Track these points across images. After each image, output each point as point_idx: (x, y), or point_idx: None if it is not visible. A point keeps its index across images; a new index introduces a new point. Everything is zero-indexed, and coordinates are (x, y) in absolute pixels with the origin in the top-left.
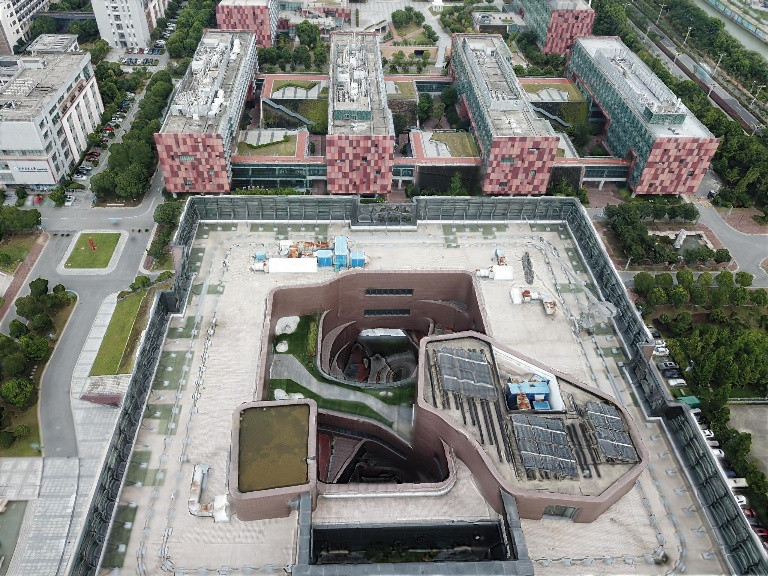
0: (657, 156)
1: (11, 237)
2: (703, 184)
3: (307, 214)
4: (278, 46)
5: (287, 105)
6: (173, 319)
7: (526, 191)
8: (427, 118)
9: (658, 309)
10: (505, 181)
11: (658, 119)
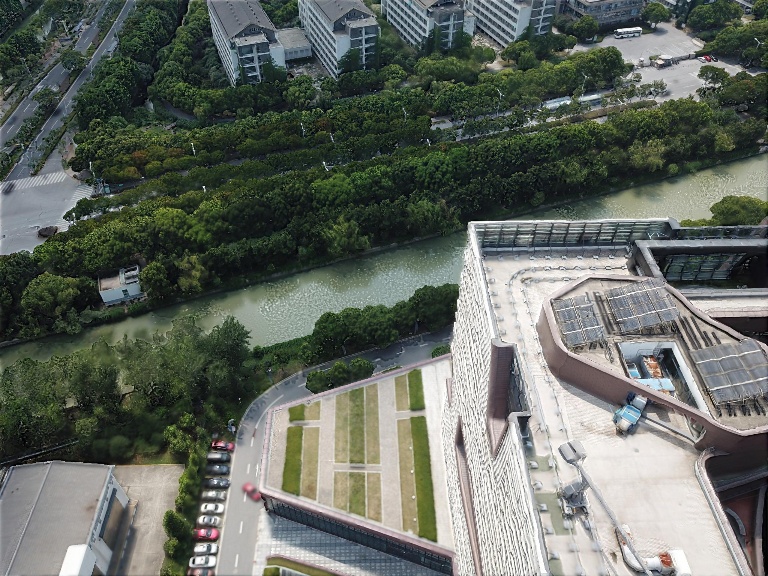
0: None
1: None
2: None
3: None
4: None
5: None
6: None
7: None
8: None
9: None
10: None
11: None
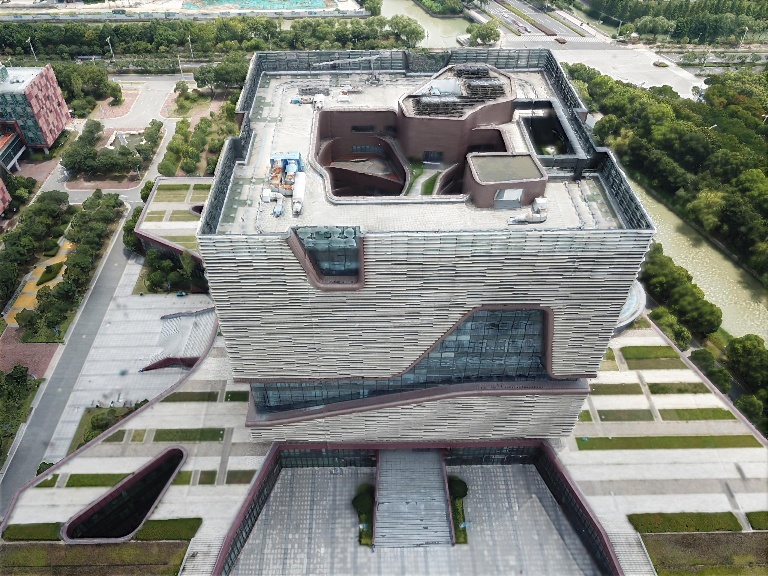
0: (36, 105)
1: None
2: None
3: None
4: None
5: None
6: None
7: (1, 209)
8: None
9: None
10: None
11: None
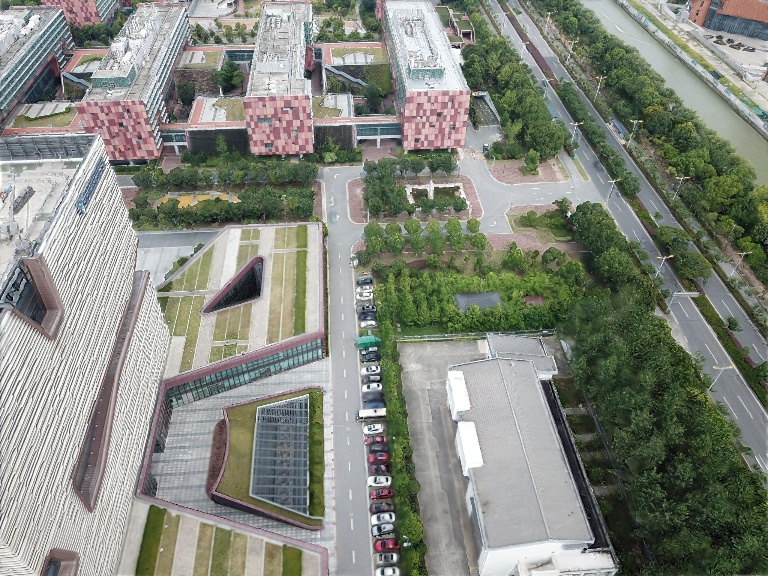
0: (412, 111)
1: None
2: (485, 139)
3: None
4: (112, 23)
5: (88, 78)
6: None
7: (294, 151)
8: (236, 86)
9: (383, 257)
10: (269, 142)
11: (417, 74)
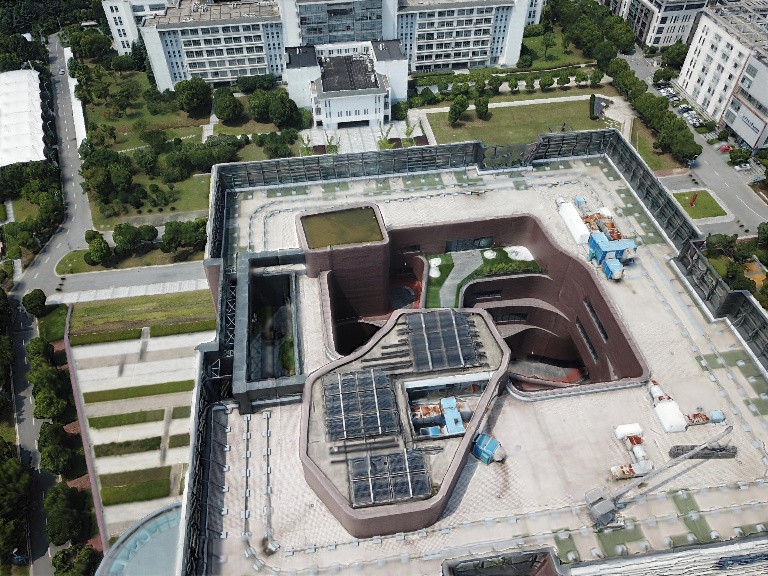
0: None
1: (668, 154)
2: None
3: (663, 218)
4: None
5: None
6: (474, 170)
7: None
8: None
9: None
10: None
11: None
